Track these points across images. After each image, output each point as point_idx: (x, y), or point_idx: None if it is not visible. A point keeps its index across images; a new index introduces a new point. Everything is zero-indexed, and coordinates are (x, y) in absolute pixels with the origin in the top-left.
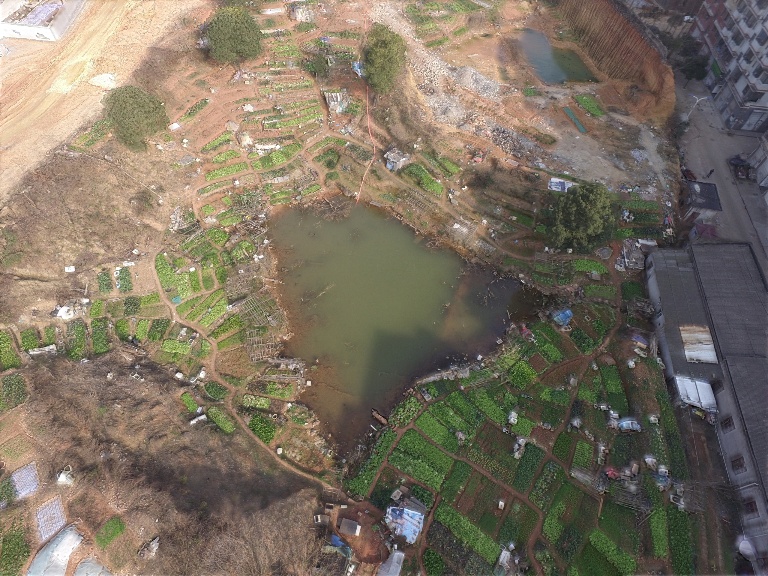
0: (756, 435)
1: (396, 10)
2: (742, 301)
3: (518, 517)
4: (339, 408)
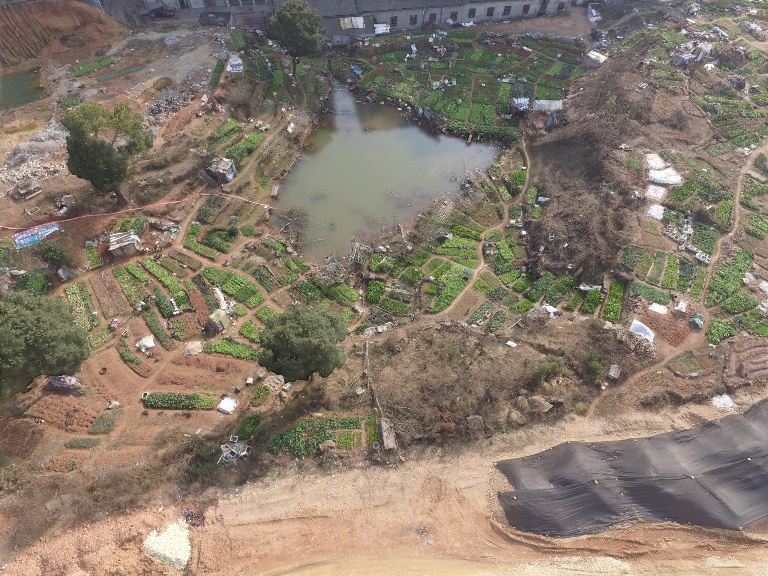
0: (402, 6)
1: None
2: (318, 3)
3: (484, 81)
4: (476, 160)
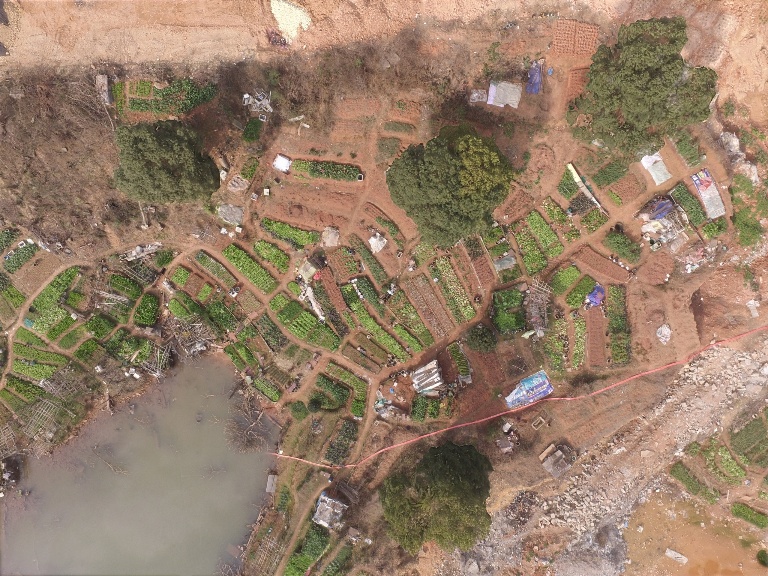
0: None
1: (765, 396)
2: None
3: None
4: None
